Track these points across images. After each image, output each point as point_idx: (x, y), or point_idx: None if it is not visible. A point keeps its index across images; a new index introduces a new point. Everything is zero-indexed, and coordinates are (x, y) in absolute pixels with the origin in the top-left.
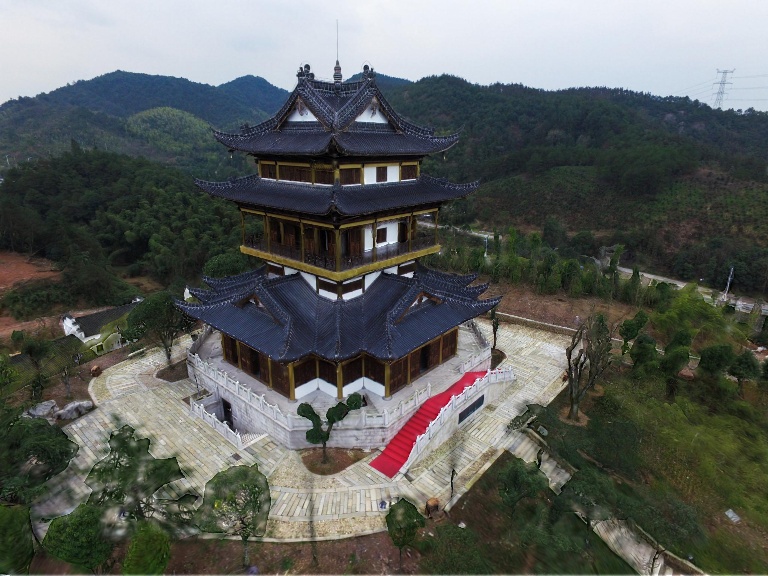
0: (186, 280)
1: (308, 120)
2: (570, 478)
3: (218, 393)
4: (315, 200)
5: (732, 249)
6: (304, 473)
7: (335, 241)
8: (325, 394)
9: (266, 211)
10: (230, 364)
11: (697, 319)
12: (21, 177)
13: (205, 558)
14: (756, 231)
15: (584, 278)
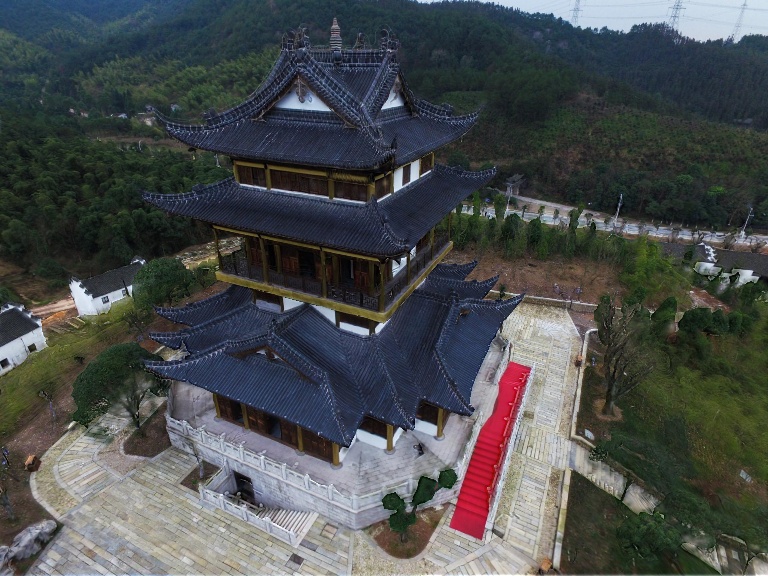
0: (53, 257)
1: (312, 109)
2: (625, 480)
3: (228, 466)
4: (349, 227)
5: (614, 174)
6: (388, 561)
7: (366, 269)
8: (369, 446)
9: (261, 233)
10: (229, 422)
11: (658, 274)
12: None
13: None
14: (630, 154)
15: (548, 238)
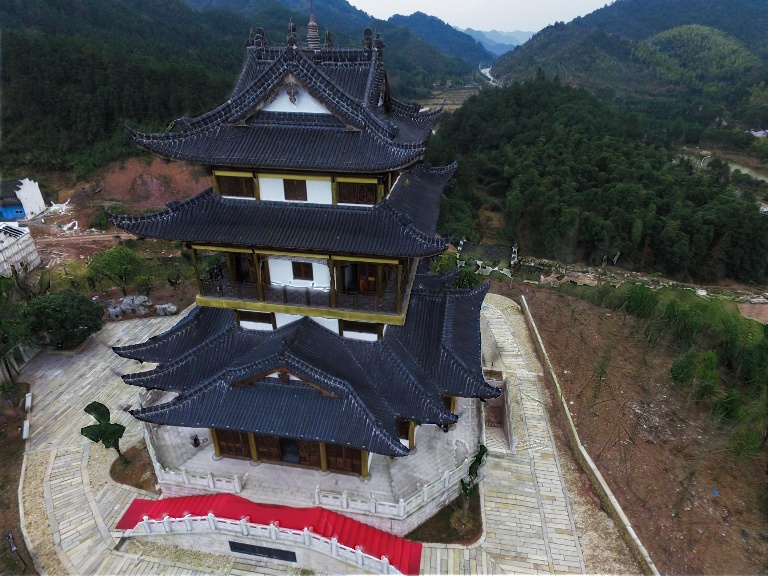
0: (524, 228)
1: None
2: None
3: None
4: None
5: None
6: (110, 459)
7: None
8: None
9: None
10: None
11: None
12: (475, 103)
13: (6, 457)
14: None
15: None
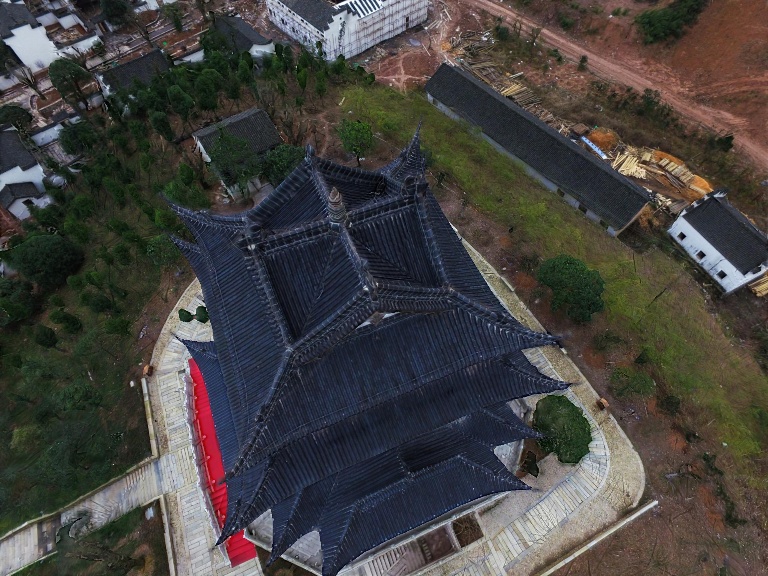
0: None
1: None
2: (122, 512)
3: None
4: None
5: None
6: None
7: None
8: None
9: None
10: None
11: None
12: None
13: None
14: None
15: None
